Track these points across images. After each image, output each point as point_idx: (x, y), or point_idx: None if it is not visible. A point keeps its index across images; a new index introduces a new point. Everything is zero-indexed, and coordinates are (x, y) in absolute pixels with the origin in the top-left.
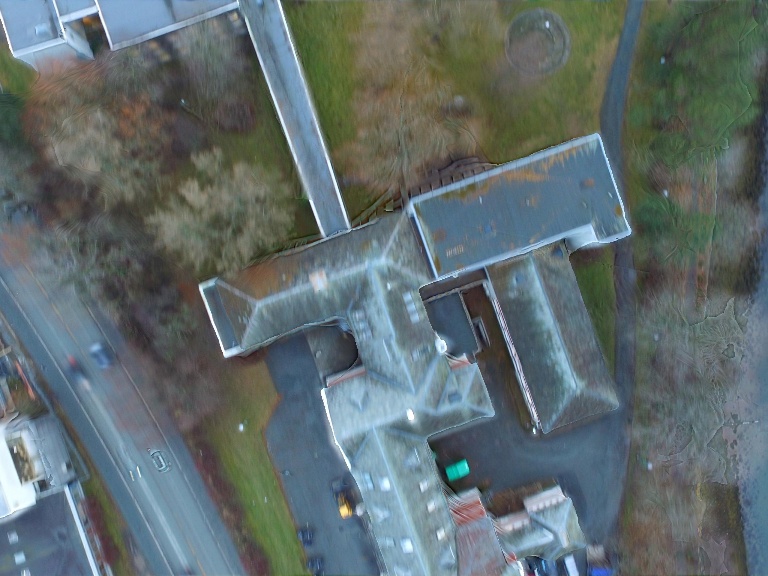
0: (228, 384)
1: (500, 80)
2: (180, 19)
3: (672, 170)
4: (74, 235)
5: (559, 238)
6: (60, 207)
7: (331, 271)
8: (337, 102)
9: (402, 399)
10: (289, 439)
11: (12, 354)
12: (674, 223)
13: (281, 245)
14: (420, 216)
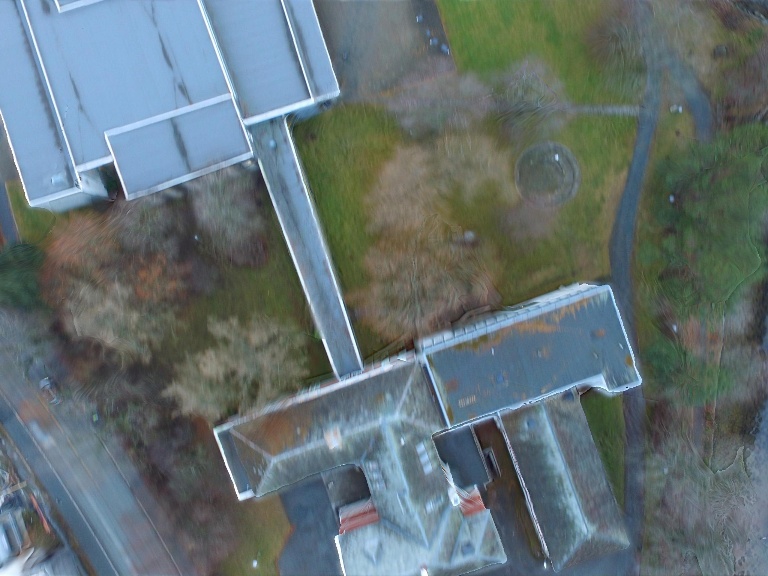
0: (241, 516)
1: (510, 213)
2: (195, 168)
3: (681, 303)
4: (92, 399)
5: (570, 387)
6: (78, 369)
7: (345, 427)
8: (349, 235)
9: (416, 554)
10: (302, 569)
11: (27, 488)
12: (683, 359)
13: (294, 387)
14: (433, 367)
